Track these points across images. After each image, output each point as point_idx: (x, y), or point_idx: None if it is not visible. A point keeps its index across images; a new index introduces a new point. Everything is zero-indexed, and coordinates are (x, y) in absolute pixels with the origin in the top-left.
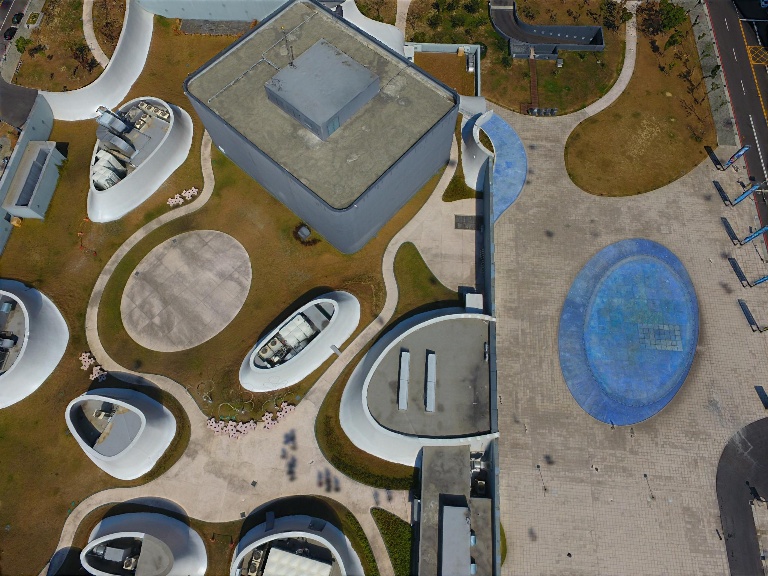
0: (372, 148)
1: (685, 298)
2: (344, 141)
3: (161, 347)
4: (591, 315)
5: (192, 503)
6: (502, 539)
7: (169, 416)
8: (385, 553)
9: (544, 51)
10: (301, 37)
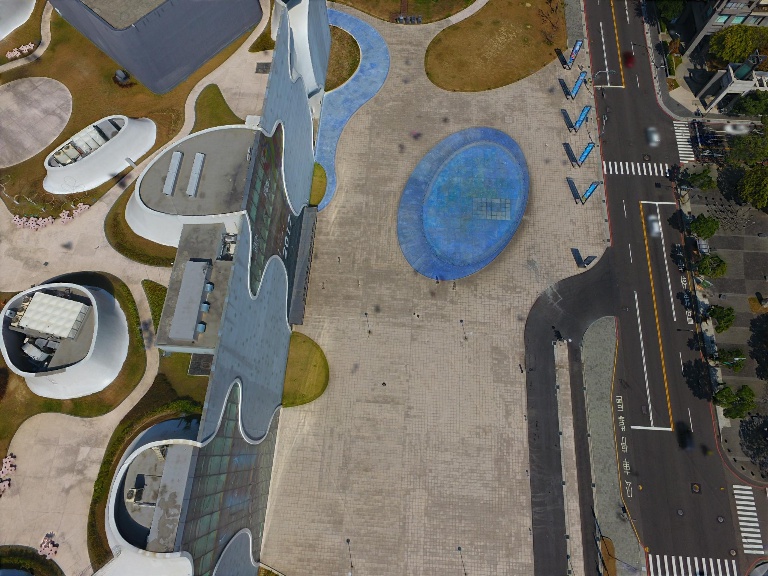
0: None
1: (519, 177)
2: None
3: None
4: (431, 191)
5: None
6: (326, 372)
7: None
8: (148, 312)
9: None
10: None
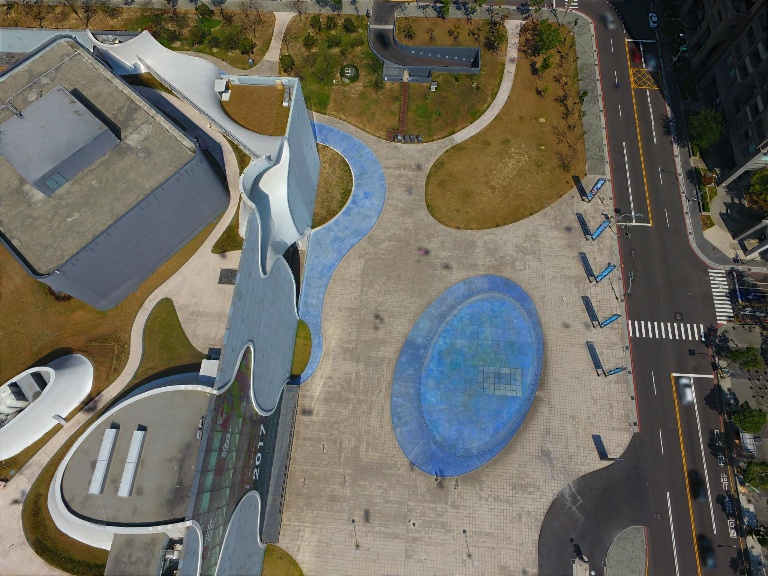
0: (96, 205)
1: (531, 339)
2: (69, 197)
3: None
4: (431, 357)
5: None
6: None
7: None
8: None
9: (420, 73)
10: (54, 80)
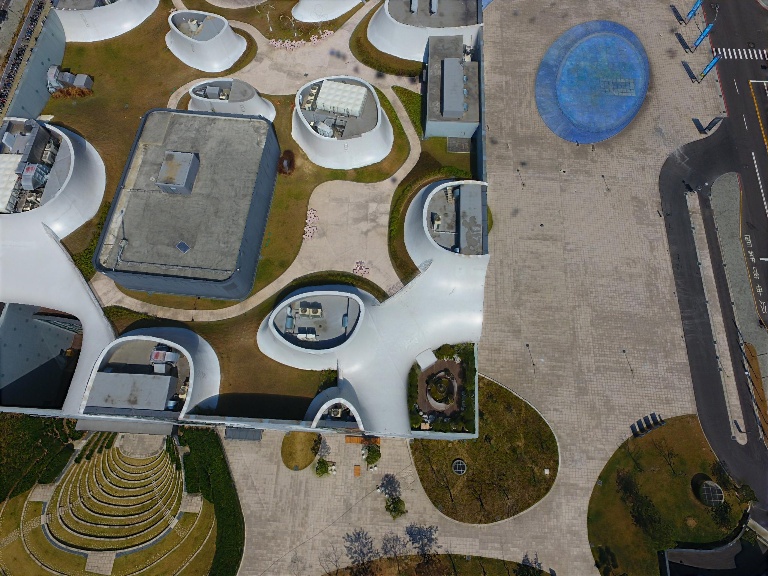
0: None
1: (639, 61)
2: None
3: (230, 6)
4: (562, 73)
5: (262, 85)
6: (489, 216)
7: (241, 37)
8: (403, 109)
9: None
10: None
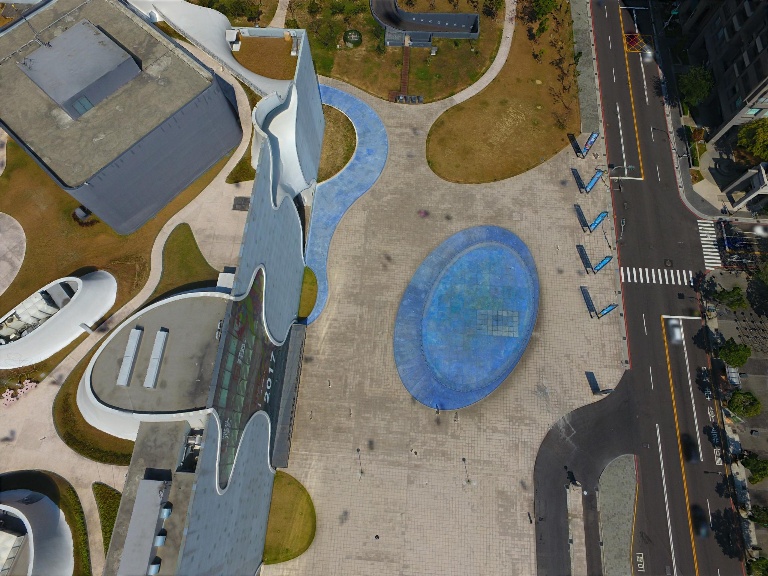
0: (121, 127)
1: (528, 285)
2: (95, 120)
3: None
4: (432, 301)
5: None
6: (312, 521)
7: None
8: (98, 527)
9: (421, 39)
10: (78, 18)
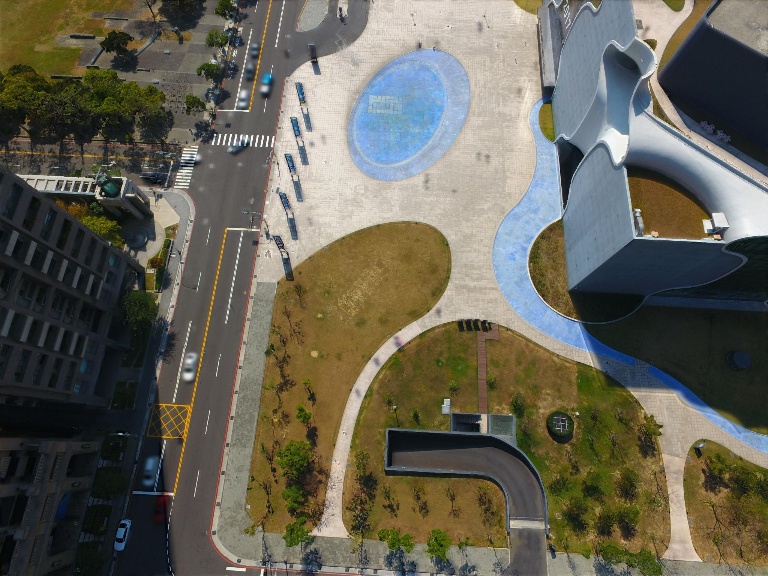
0: None
1: (357, 133)
2: None
3: None
4: (440, 119)
5: None
6: None
7: None
8: None
9: None
10: None
